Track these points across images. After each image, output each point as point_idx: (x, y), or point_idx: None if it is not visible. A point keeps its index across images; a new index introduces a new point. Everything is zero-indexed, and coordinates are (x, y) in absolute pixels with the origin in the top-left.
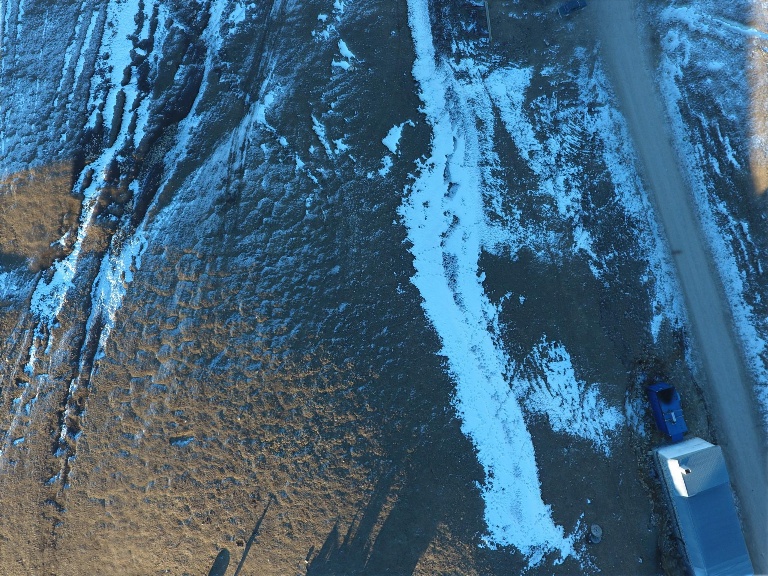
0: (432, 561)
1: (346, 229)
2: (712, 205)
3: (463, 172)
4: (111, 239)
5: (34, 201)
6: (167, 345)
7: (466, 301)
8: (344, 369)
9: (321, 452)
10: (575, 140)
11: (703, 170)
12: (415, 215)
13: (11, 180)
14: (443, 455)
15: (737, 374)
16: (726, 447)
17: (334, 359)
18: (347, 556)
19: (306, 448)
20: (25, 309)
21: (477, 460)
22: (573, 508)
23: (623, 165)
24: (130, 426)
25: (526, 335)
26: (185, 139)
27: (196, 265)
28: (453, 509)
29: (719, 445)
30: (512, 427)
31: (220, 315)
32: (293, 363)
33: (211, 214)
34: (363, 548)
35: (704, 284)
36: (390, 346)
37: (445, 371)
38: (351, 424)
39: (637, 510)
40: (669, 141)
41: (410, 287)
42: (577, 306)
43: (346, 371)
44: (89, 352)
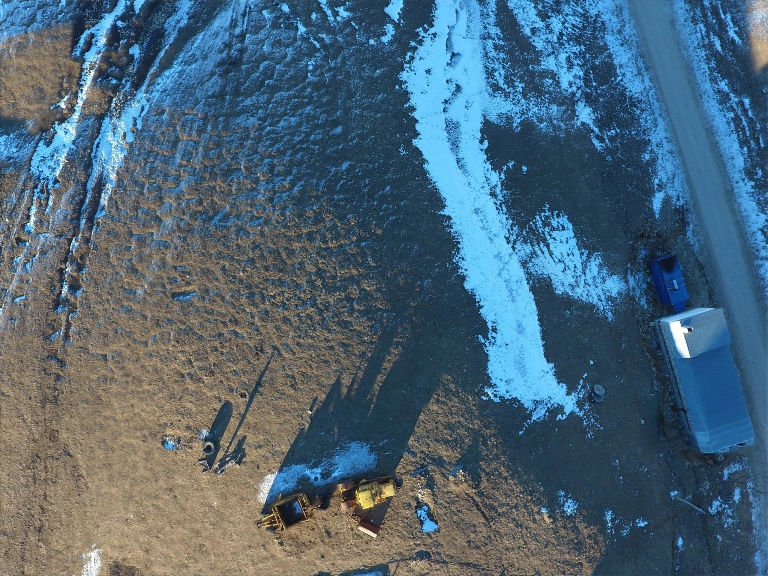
0: (436, 411)
1: (348, 92)
2: (713, 84)
3: (465, 43)
4: (112, 102)
5: (33, 64)
6: (169, 203)
7: (469, 166)
8: (347, 225)
9: (324, 305)
10: (577, 21)
11: (705, 49)
12: (417, 81)
13: (10, 44)
14: (446, 309)
15: (738, 249)
16: (727, 321)
17: (337, 215)
18: (351, 406)
19: (309, 301)
20: (25, 170)
21: (480, 315)
22: (576, 368)
23: (625, 46)
24: (132, 282)
25: (529, 204)
26: (186, 6)
27: (198, 125)
28: (456, 361)
29: (721, 308)
30: (515, 287)
31: (222, 173)
32: (296, 219)
33: (212, 76)
34: (367, 398)
35: (705, 162)
36: (393, 204)
37: (448, 230)
38: (354, 278)
39: (639, 374)
40: (671, 22)
41: (413, 149)
42: (579, 177)
43: (349, 227)
44: (90, 211)
